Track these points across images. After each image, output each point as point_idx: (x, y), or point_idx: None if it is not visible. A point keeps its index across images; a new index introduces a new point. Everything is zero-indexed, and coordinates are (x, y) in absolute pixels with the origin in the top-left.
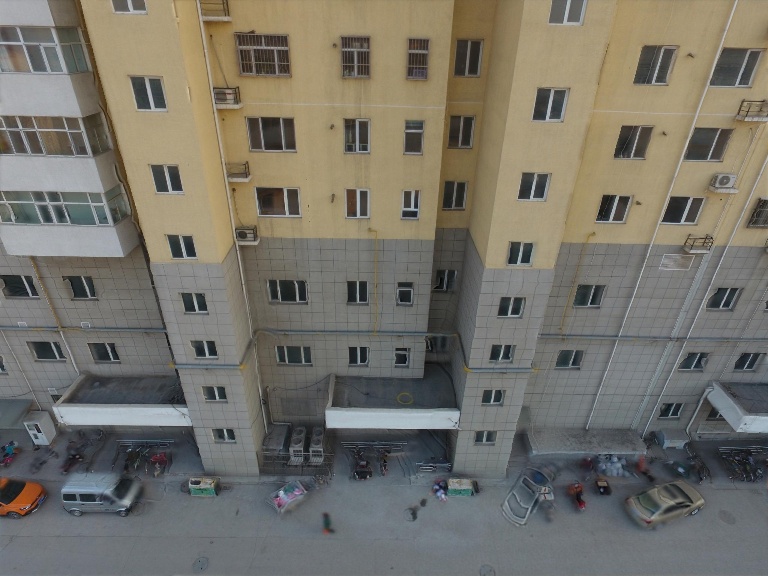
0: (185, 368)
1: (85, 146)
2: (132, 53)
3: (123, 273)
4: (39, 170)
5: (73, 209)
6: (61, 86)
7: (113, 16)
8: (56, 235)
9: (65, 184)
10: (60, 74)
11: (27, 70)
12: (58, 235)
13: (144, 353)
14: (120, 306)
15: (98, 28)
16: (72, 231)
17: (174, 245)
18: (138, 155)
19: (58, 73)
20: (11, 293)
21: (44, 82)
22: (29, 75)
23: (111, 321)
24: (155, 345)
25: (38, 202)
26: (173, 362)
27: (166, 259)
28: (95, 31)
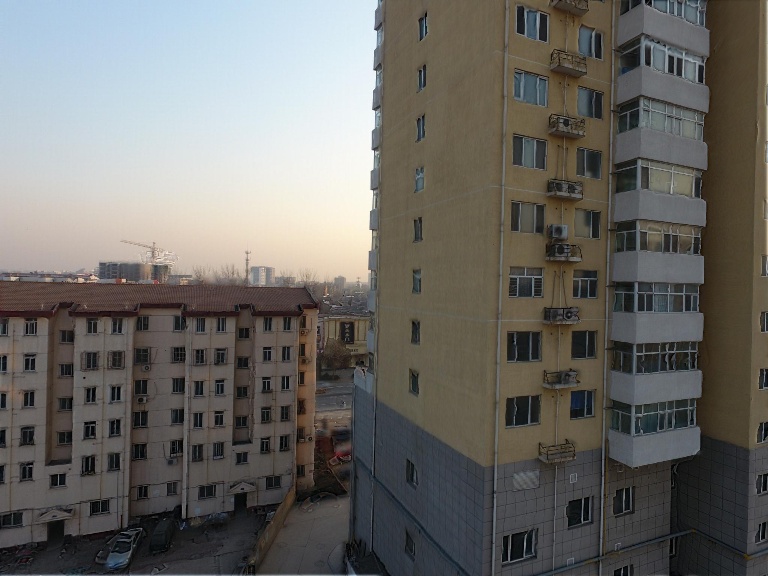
0: (759, 557)
1: (694, 362)
2: (765, 298)
3: (656, 477)
4: (673, 383)
5: (679, 414)
6: (697, 320)
7: (763, 278)
8: (667, 440)
9: (682, 393)
10: (697, 312)
11: (678, 311)
12: (668, 440)
13: (651, 570)
14: (647, 515)
15: (757, 285)
16: (677, 435)
17: (759, 432)
18: (758, 363)
19: (695, 312)
20: (574, 521)
21: (691, 318)
22: (685, 314)
23: (637, 536)
24: (660, 557)
25: (661, 411)
26: (746, 554)
27: (756, 445)
28: (756, 286)
